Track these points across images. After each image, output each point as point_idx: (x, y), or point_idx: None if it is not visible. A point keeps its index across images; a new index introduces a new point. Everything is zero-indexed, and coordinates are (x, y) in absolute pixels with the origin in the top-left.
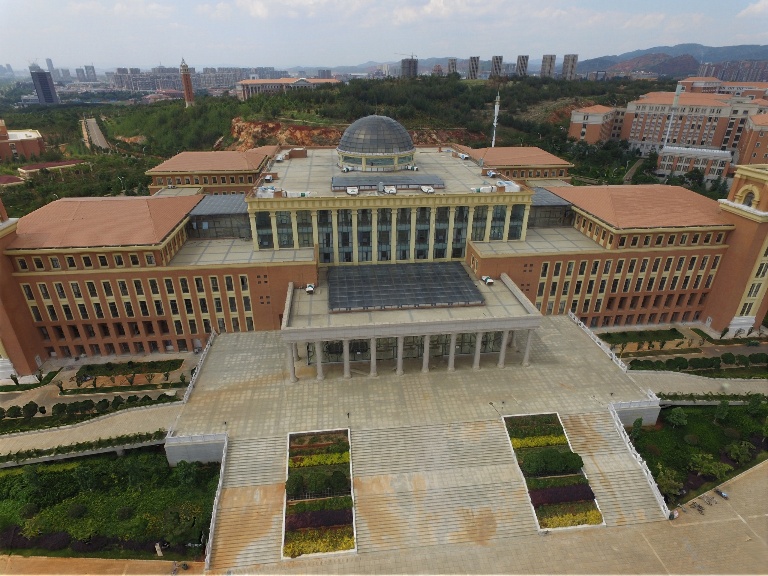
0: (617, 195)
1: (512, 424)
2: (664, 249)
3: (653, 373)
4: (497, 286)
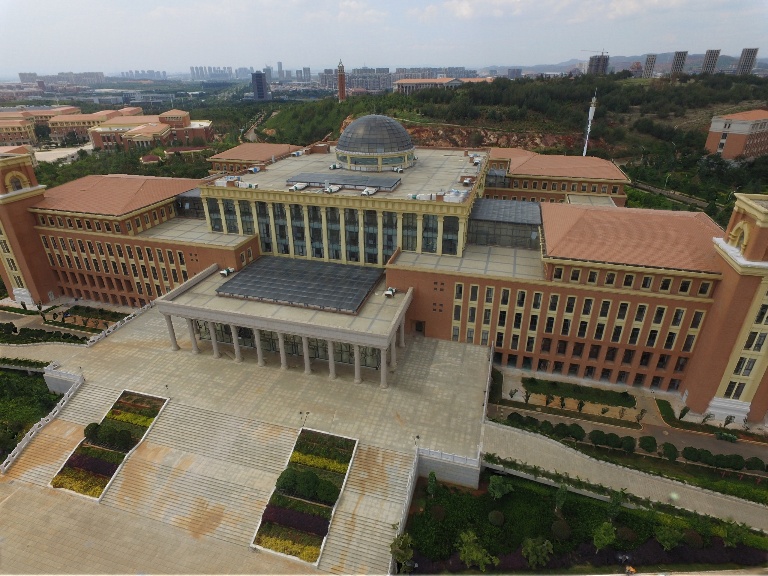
0: (590, 218)
1: (305, 437)
2: (613, 290)
3: (519, 432)
4: (395, 299)
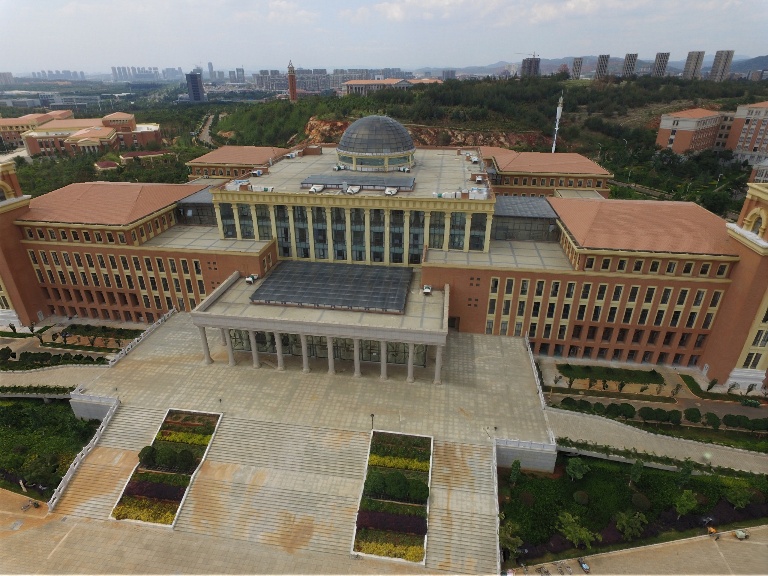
0: (607, 210)
1: (378, 440)
2: (642, 276)
3: (579, 415)
4: (434, 297)
